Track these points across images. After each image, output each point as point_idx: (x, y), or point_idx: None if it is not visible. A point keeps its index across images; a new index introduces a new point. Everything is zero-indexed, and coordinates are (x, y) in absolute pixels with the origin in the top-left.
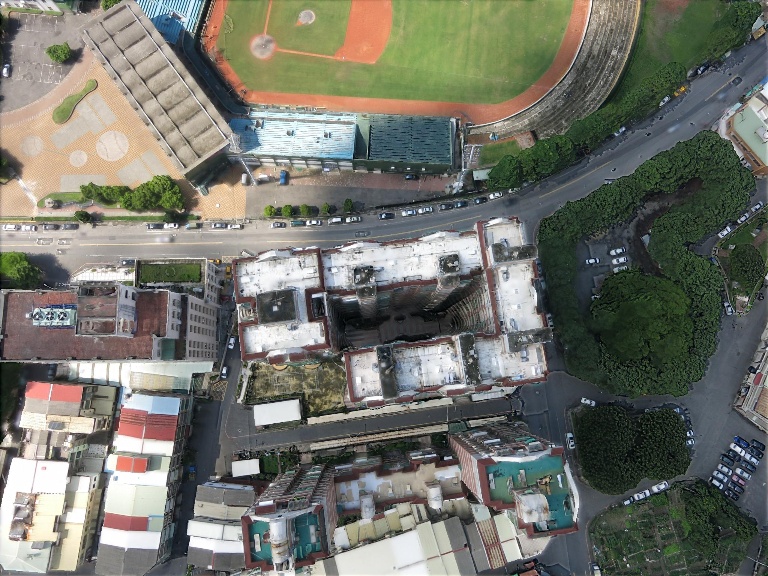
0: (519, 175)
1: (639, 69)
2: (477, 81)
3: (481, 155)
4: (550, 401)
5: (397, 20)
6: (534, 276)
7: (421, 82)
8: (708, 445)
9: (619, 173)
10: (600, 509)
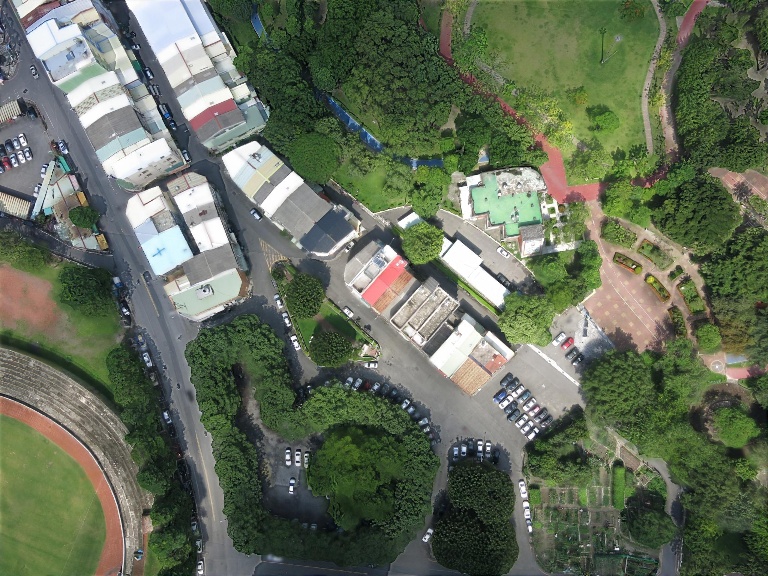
0: (180, 568)
1: None
2: (76, 550)
3: (154, 574)
4: (418, 573)
5: None
6: None
7: None
8: (495, 429)
9: None
10: (531, 554)
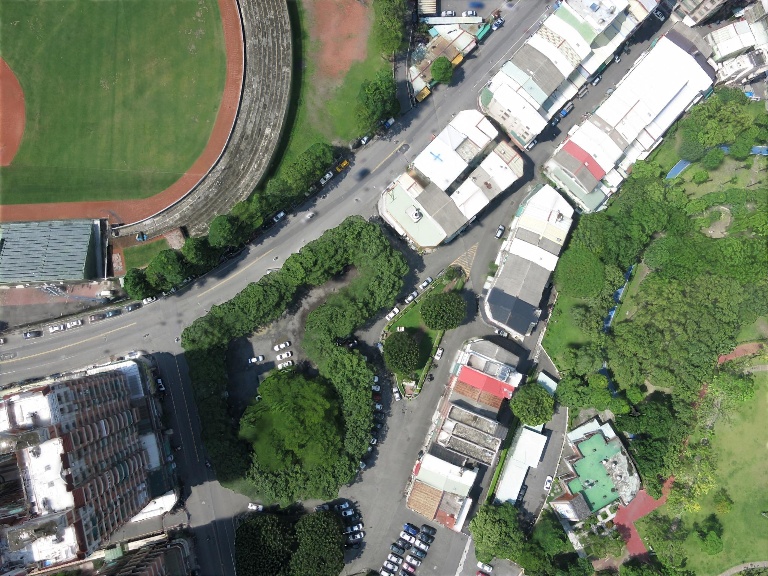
0: (148, 288)
1: (299, 145)
2: (124, 175)
3: (128, 259)
4: (217, 510)
5: (31, 113)
6: (63, 451)
7: (62, 182)
8: (379, 536)
9: (282, 261)
10: None
